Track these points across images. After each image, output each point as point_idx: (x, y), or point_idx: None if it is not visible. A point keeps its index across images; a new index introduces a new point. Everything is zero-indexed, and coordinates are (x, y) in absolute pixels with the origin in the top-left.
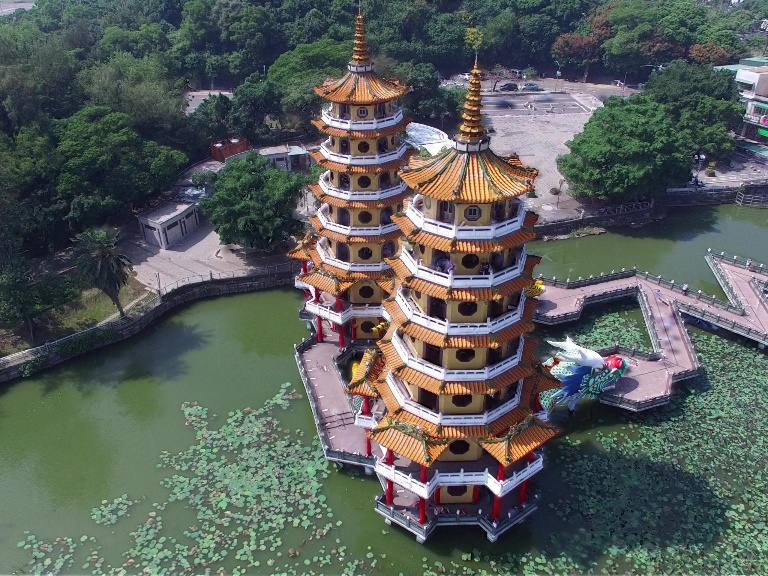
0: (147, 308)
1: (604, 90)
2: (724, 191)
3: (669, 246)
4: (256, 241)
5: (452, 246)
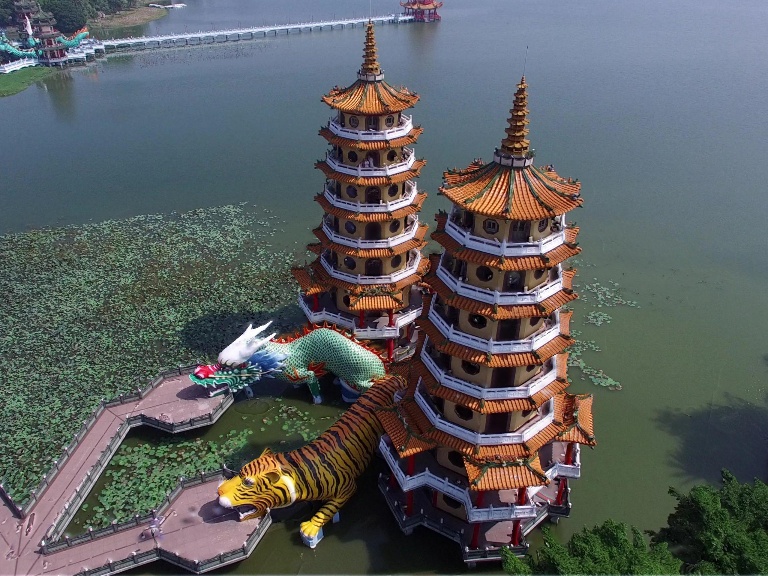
0: None
1: None
2: None
3: None
4: None
5: None
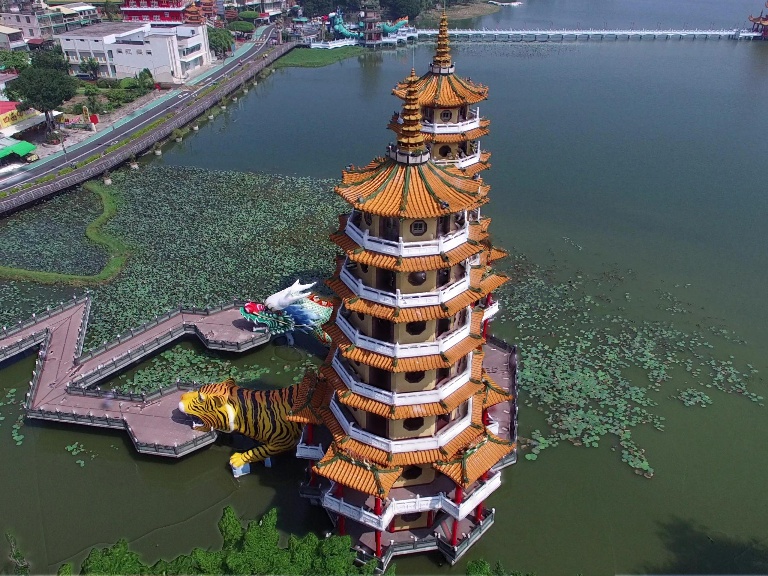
0: None
1: None
2: None
3: None
4: None
5: None
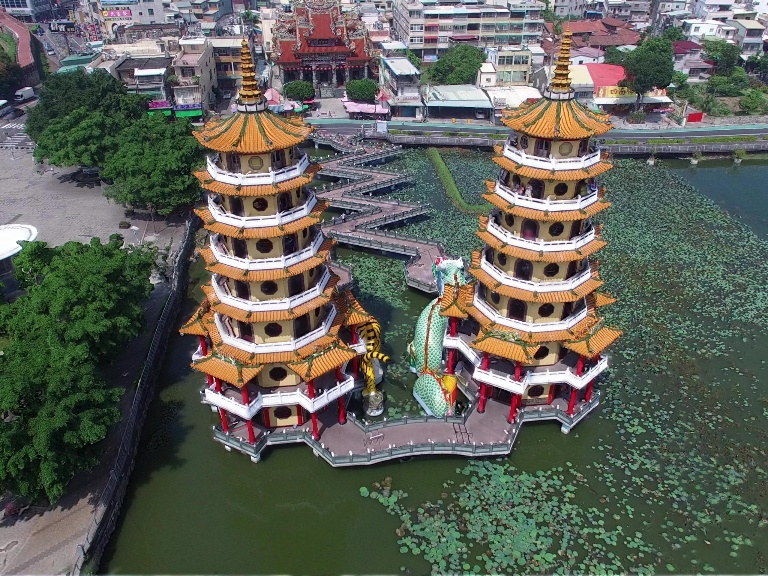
0: None
1: None
2: None
3: None
4: None
5: None
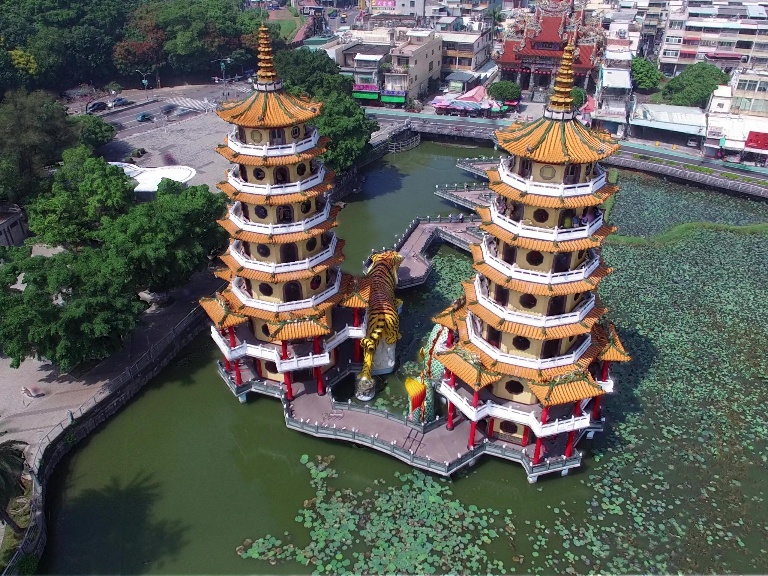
0: (35, 502)
1: (187, 91)
2: (381, 145)
3: (395, 197)
4: (105, 346)
5: (601, 198)
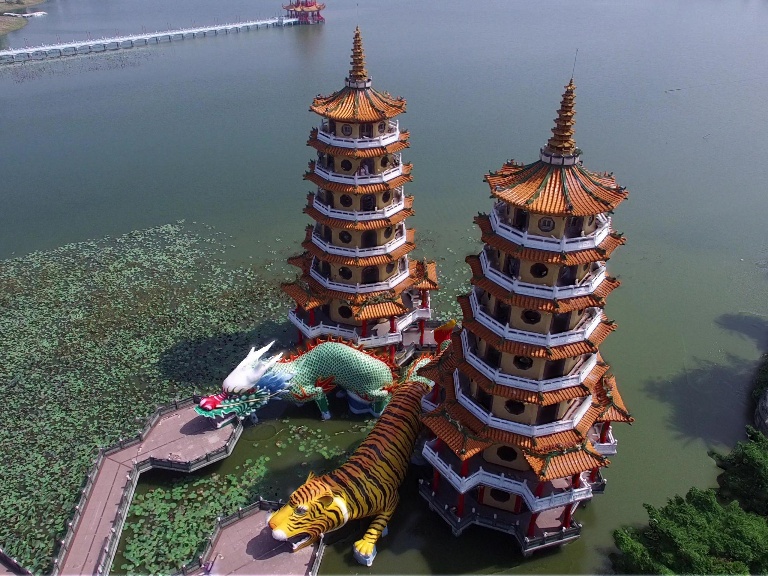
0: None
1: None
2: None
3: None
4: None
5: None
